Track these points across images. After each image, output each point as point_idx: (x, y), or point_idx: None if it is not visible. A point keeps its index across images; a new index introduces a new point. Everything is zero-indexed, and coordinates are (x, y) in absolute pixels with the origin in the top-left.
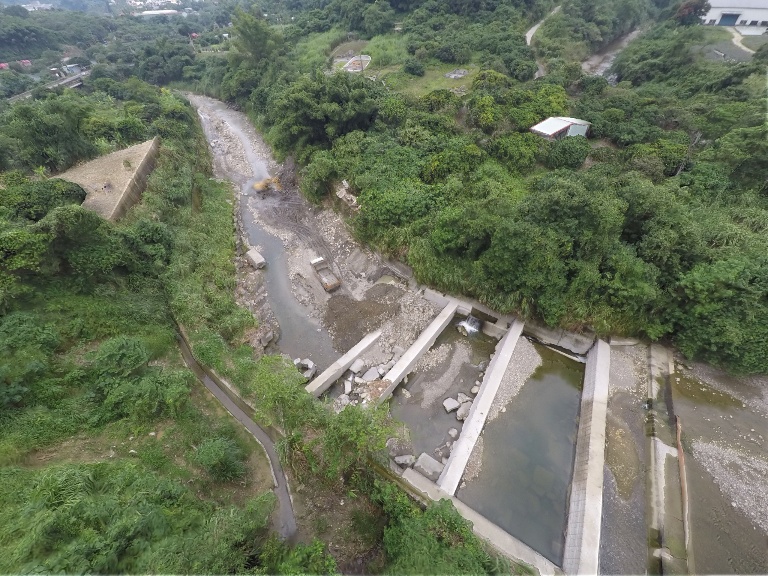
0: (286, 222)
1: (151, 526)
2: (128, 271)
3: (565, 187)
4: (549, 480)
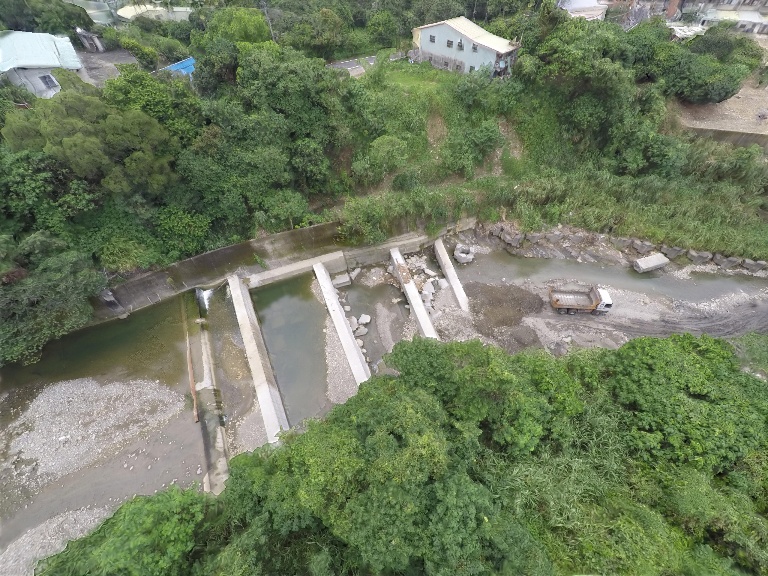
0: (759, 321)
1: (366, 124)
2: (603, 148)
3: (411, 426)
4: (274, 323)
